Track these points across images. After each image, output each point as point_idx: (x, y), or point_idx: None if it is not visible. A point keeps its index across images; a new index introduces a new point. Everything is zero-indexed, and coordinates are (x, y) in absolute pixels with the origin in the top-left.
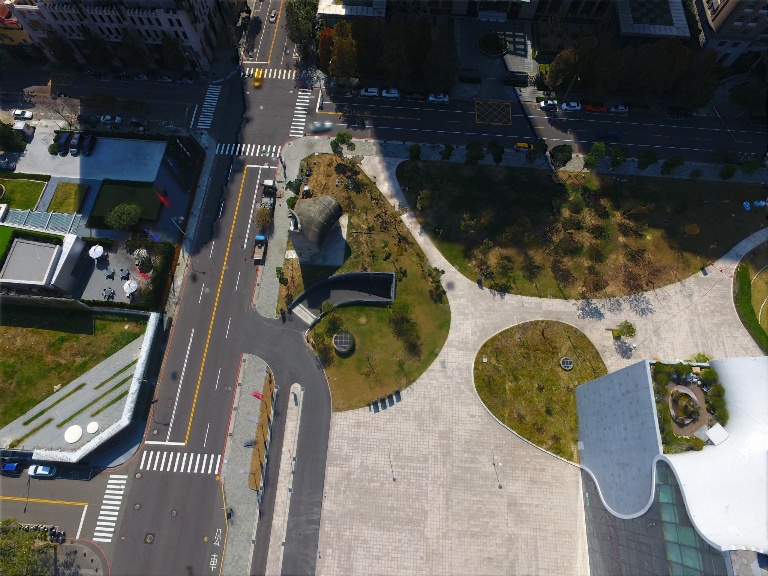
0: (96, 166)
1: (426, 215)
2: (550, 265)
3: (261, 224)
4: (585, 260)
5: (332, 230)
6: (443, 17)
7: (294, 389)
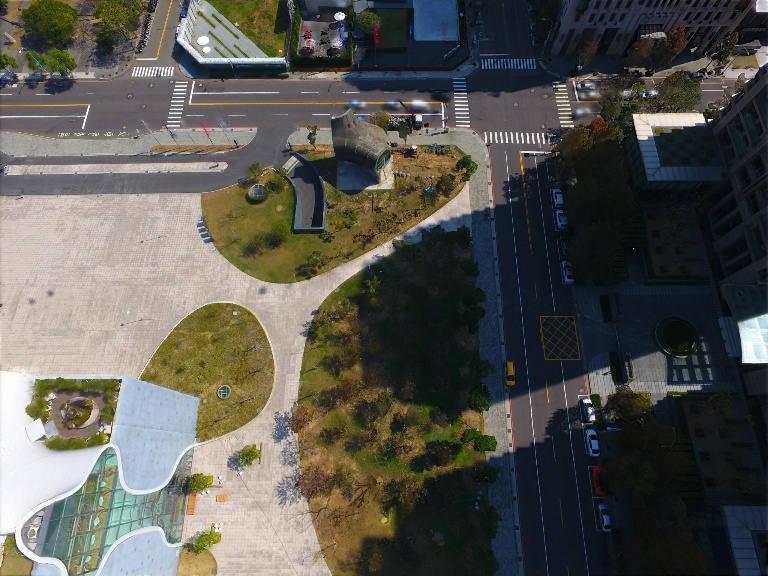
0: (426, 1)
1: (400, 261)
2: (340, 387)
3: (372, 117)
4: (348, 429)
5: (373, 176)
6: (694, 263)
7: (223, 164)
